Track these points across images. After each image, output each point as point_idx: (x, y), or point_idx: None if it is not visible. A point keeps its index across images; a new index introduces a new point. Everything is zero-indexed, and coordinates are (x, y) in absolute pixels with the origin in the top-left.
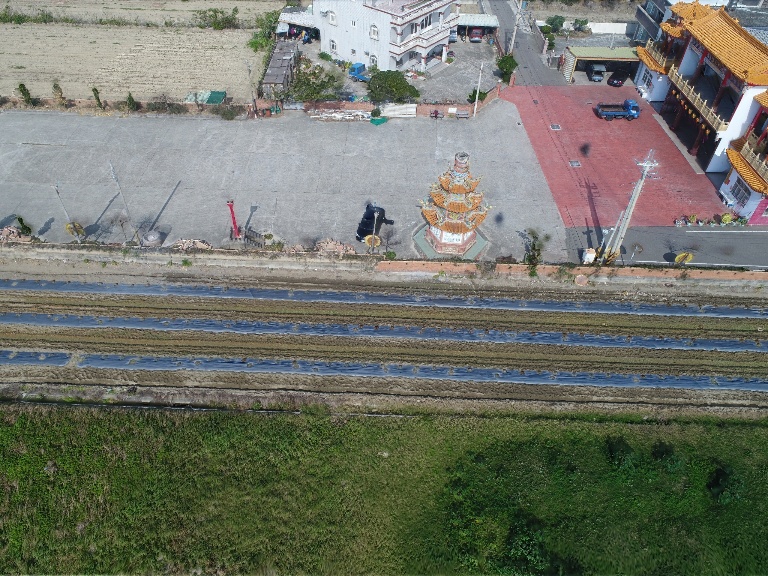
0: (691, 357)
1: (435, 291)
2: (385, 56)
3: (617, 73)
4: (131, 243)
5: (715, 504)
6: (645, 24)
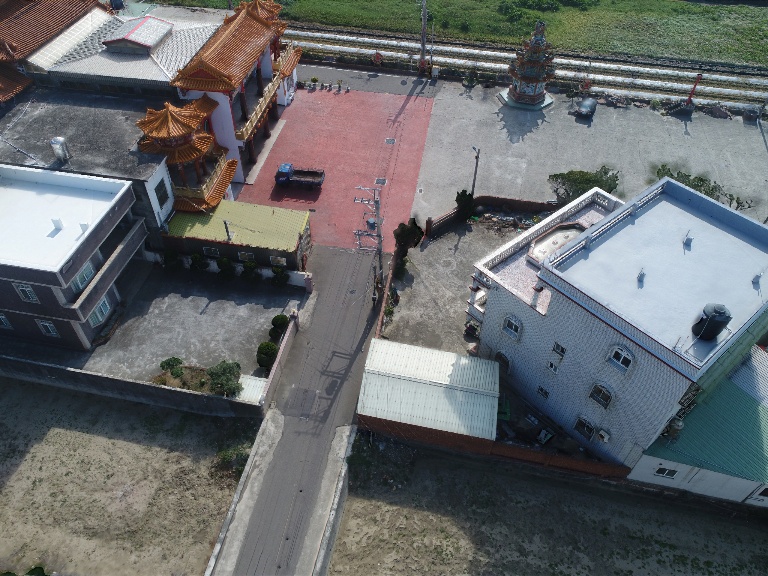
0: (400, 51)
1: None
2: None
3: None
4: (767, 119)
5: None
6: (113, 275)
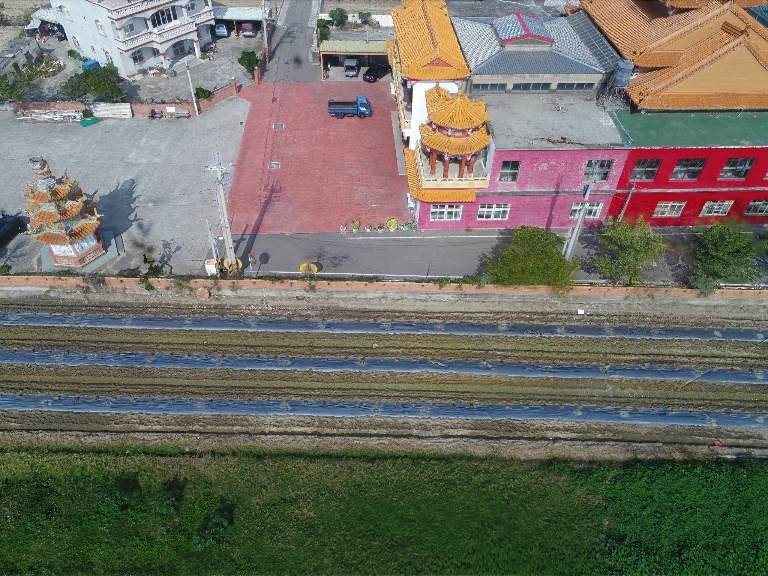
0: (278, 378)
1: (40, 308)
2: (116, 53)
3: (371, 68)
4: None
5: (193, 550)
6: None
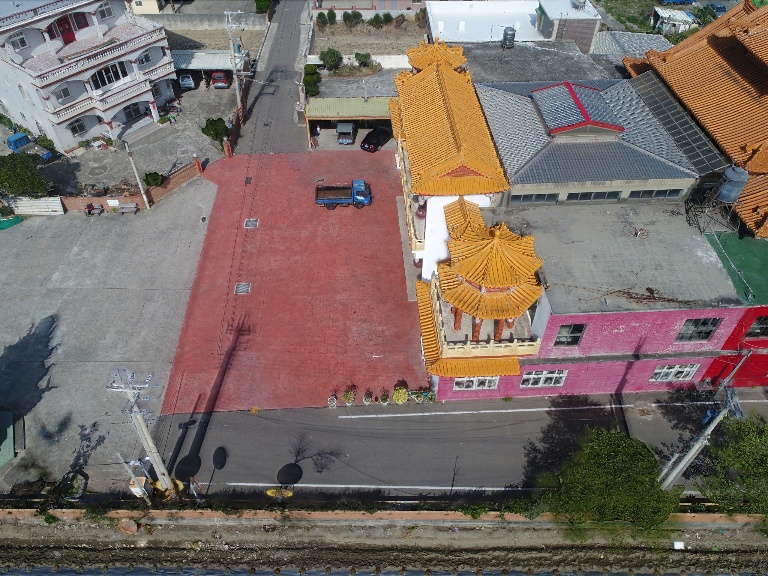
0: None
1: None
2: (48, 124)
3: (370, 134)
4: None
5: None
6: None
